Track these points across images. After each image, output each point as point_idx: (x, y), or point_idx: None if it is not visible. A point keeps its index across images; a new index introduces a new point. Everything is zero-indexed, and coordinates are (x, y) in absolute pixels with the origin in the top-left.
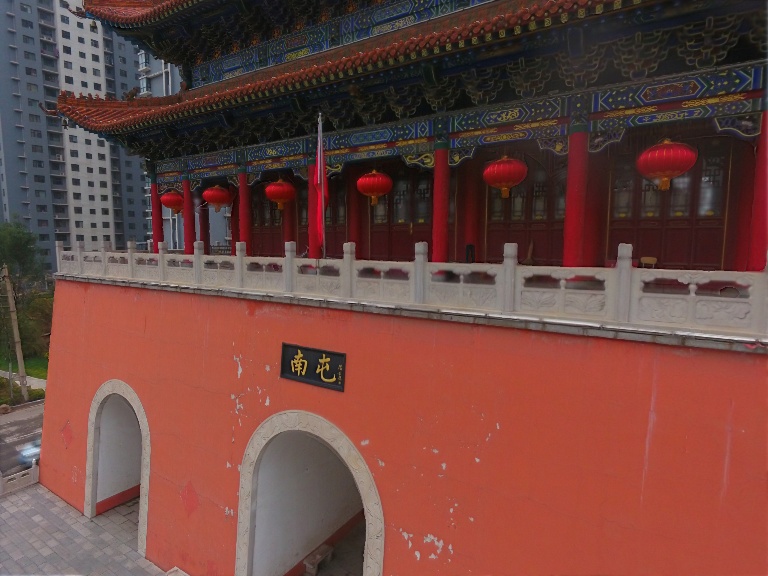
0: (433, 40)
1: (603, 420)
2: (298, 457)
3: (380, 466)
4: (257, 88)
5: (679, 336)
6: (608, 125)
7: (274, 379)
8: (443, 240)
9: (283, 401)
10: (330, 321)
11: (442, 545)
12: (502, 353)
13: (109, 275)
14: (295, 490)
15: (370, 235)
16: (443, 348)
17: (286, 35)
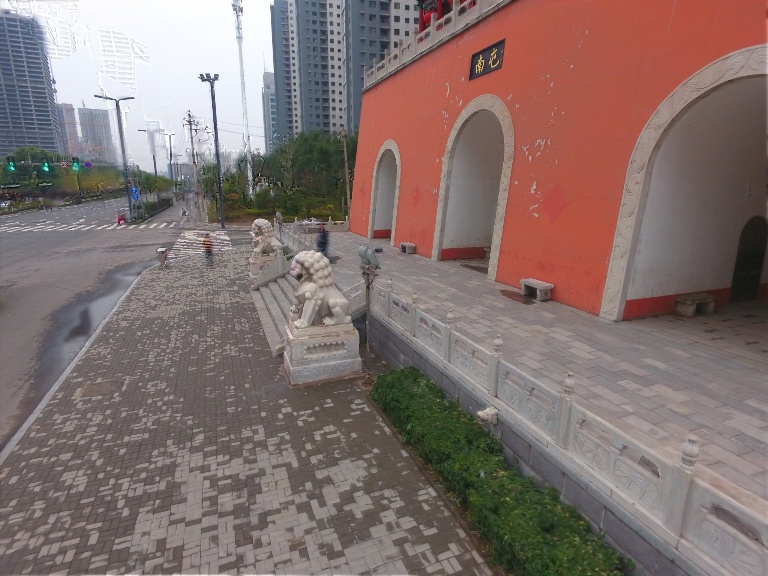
0: None
1: None
2: (485, 166)
3: (516, 108)
4: None
5: None
6: None
7: (465, 84)
8: None
9: (469, 97)
10: (499, 20)
11: (544, 143)
12: None
13: None
14: (481, 190)
15: None
16: None
17: None
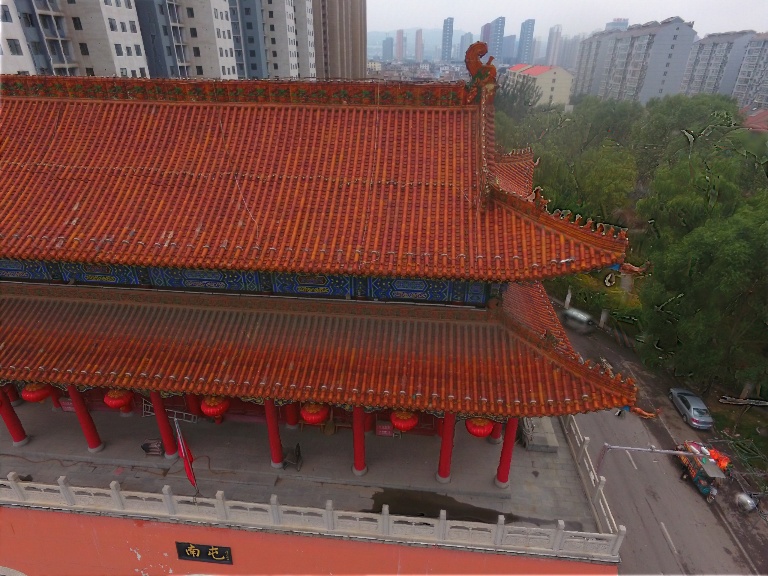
0: (264, 396)
1: (380, 569)
2: None
3: None
4: None
5: None
6: None
7: (173, 560)
8: (278, 446)
9: (185, 570)
10: (214, 532)
11: None
12: (330, 547)
13: None
14: None
15: None
16: (296, 544)
17: None
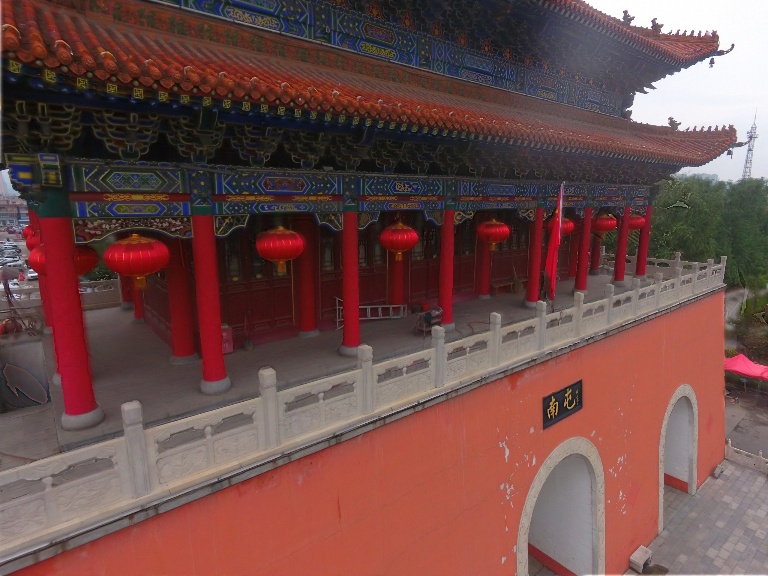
0: (614, 148)
1: None
2: None
3: (600, 441)
4: (507, 133)
5: (669, 308)
6: (597, 204)
7: (538, 436)
8: None
9: (546, 449)
10: (573, 359)
11: None
12: (636, 338)
13: (169, 482)
14: None
15: (410, 273)
16: (619, 347)
17: (363, 14)
